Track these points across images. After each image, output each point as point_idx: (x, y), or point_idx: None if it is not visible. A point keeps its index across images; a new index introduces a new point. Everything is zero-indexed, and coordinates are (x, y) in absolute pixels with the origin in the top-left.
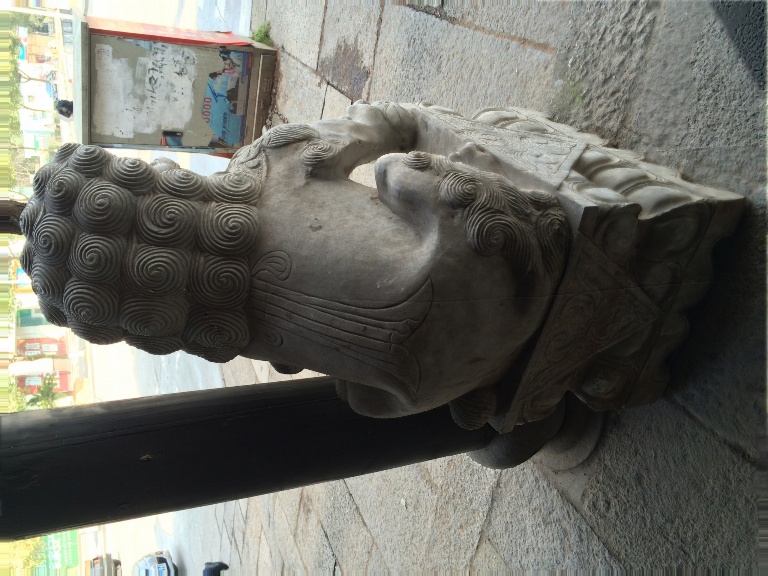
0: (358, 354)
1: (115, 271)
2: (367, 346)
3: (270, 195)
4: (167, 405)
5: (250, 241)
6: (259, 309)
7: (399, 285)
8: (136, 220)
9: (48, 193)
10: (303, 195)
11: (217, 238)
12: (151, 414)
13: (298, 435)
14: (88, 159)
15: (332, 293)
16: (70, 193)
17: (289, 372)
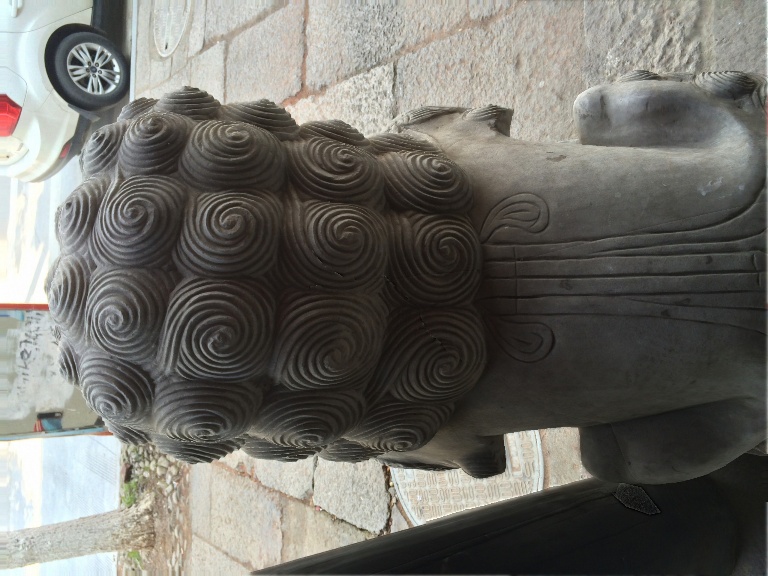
0: (705, 310)
1: (271, 247)
2: (720, 288)
3: (458, 148)
4: (331, 558)
5: (467, 190)
6: (504, 295)
7: (733, 184)
8: (292, 166)
9: (133, 139)
10: (504, 141)
11: (422, 185)
12: (317, 574)
13: (547, 574)
14: (193, 95)
15: (634, 222)
16: (175, 133)
17: (496, 468)
